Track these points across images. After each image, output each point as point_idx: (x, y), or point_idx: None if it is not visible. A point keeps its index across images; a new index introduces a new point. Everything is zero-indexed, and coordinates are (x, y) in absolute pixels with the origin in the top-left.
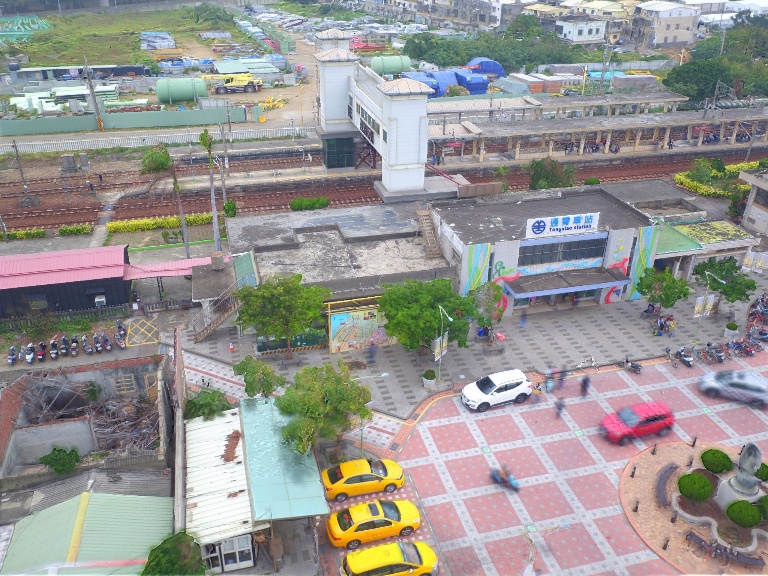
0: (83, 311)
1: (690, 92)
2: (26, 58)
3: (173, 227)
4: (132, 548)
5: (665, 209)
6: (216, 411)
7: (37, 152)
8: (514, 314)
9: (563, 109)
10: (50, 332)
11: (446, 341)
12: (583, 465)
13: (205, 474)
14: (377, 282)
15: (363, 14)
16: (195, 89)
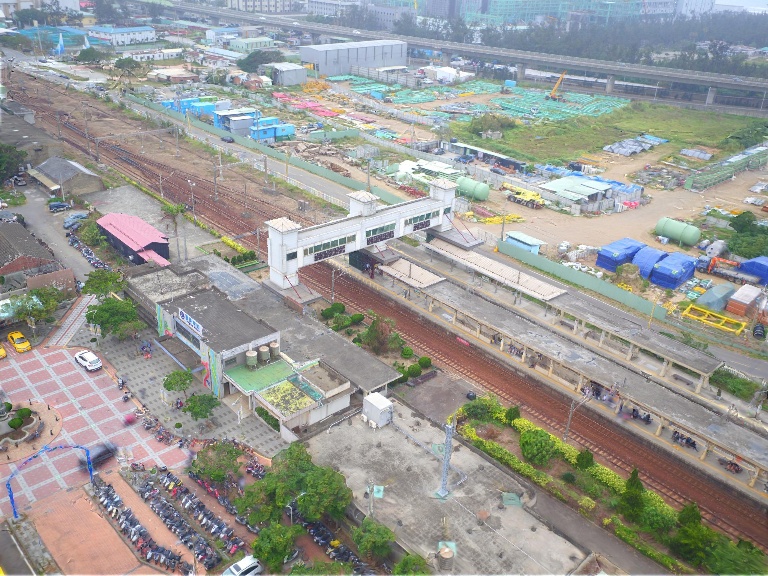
0: (126, 258)
1: None
2: (499, 135)
3: (239, 252)
4: None
5: (332, 380)
6: (31, 295)
7: (313, 194)
8: None
9: None
10: (115, 260)
11: (100, 330)
12: (40, 392)
13: None
14: None
15: None
16: (474, 191)
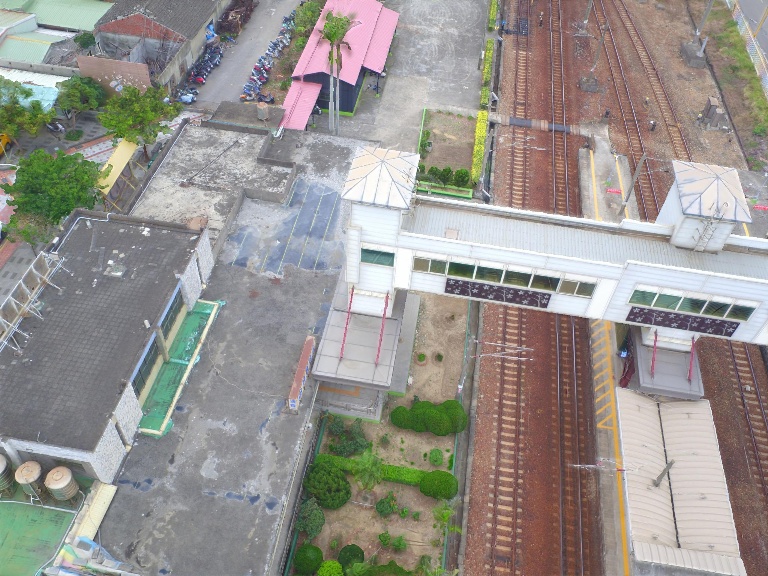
0: None
1: None
2: None
3: None
4: (9, 56)
5: None
6: None
7: (765, 95)
8: None
9: None
10: None
11: None
12: None
13: (25, 76)
14: None
15: None
16: None
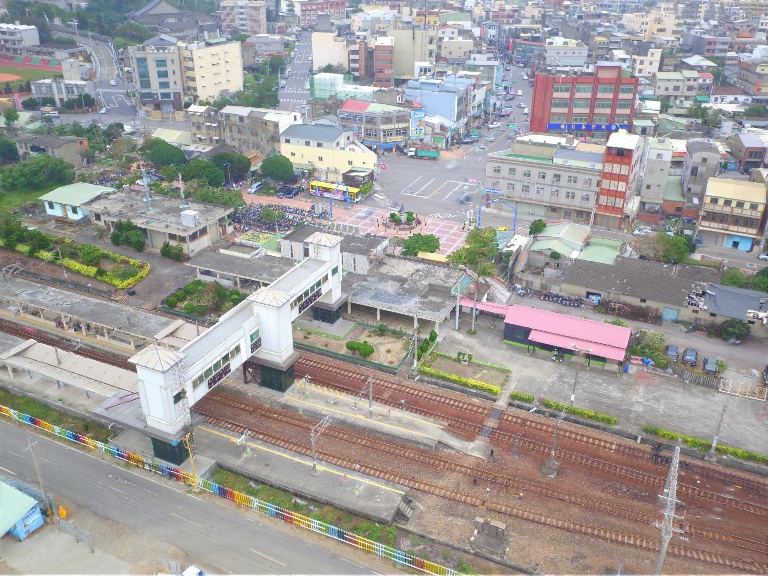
0: None
1: None
2: None
3: None
4: None
5: None
6: None
7: None
8: None
9: None
10: None
11: None
12: None
13: None
14: None
15: None
16: None
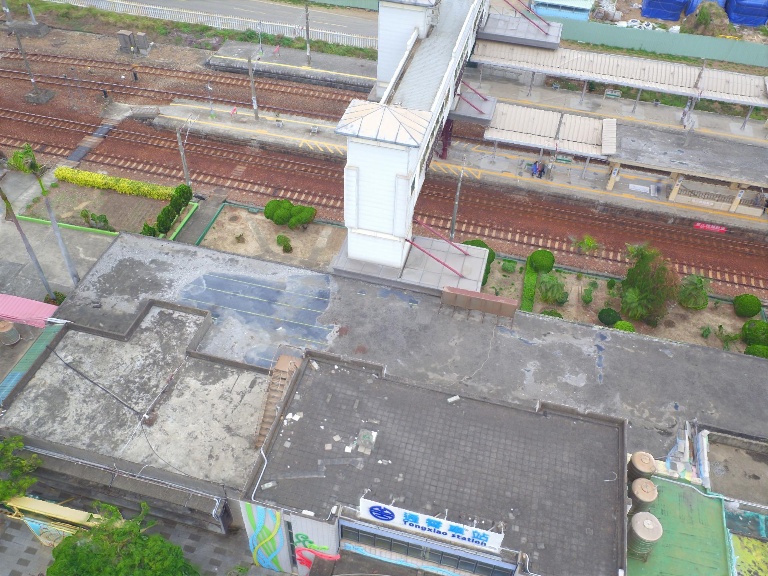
0: None
1: None
2: None
3: (126, 193)
4: None
5: None
6: None
7: (118, 12)
8: None
9: None
10: None
11: None
12: None
13: None
14: (138, 471)
15: None
16: None
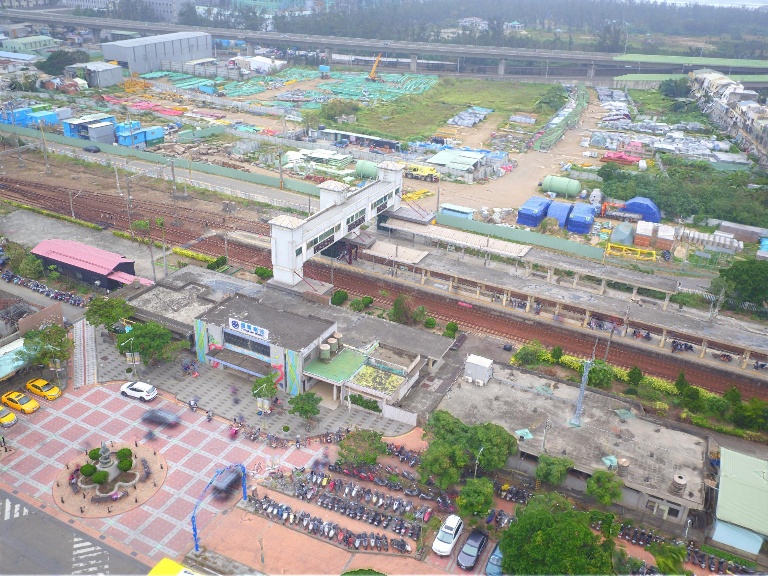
0: (90, 285)
1: (726, 289)
2: (354, 118)
3: (200, 260)
4: None
5: (401, 357)
6: None
7: (228, 194)
8: (226, 370)
9: (549, 266)
10: (75, 289)
11: (138, 357)
12: (110, 433)
13: None
14: (166, 321)
15: (697, 119)
16: None
